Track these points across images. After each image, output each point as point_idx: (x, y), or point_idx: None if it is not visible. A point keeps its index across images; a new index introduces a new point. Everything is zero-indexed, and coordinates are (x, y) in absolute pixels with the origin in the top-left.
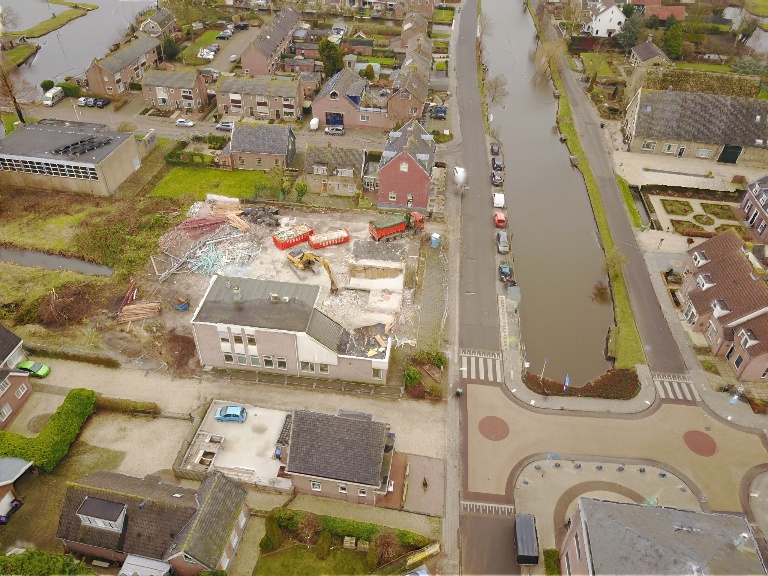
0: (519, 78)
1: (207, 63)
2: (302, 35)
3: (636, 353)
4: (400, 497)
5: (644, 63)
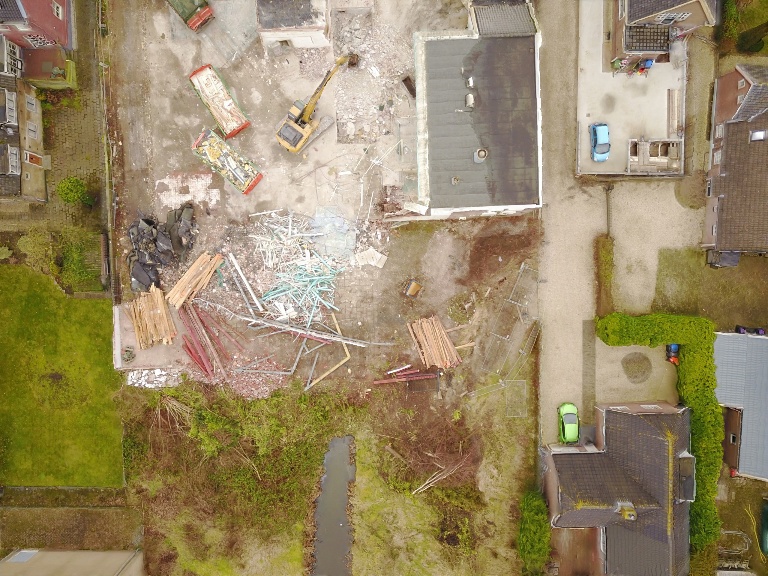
0: None
1: None
2: None
3: None
4: None
5: None
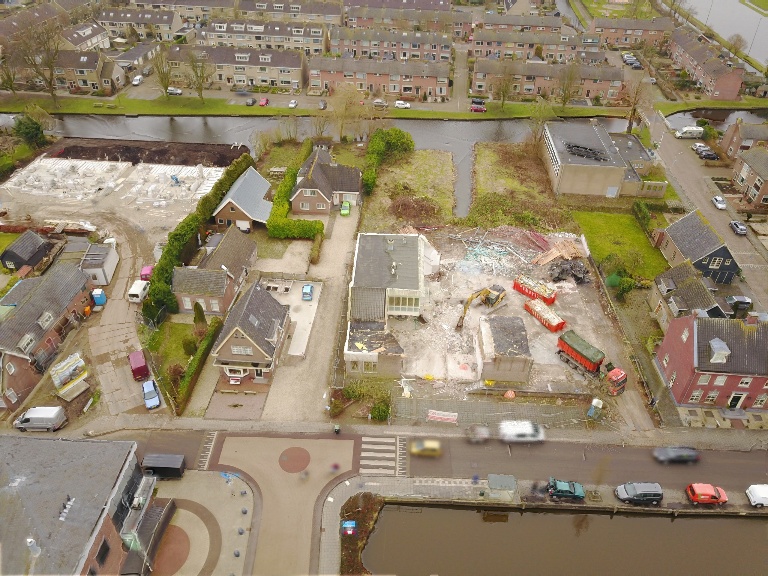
0: None
1: None
2: None
3: None
4: None
5: None
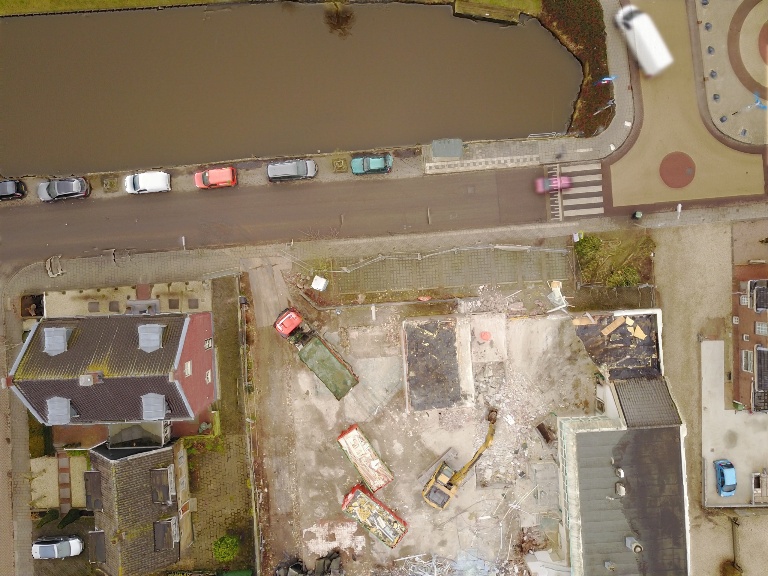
0: None
1: None
2: None
3: None
4: None
5: None
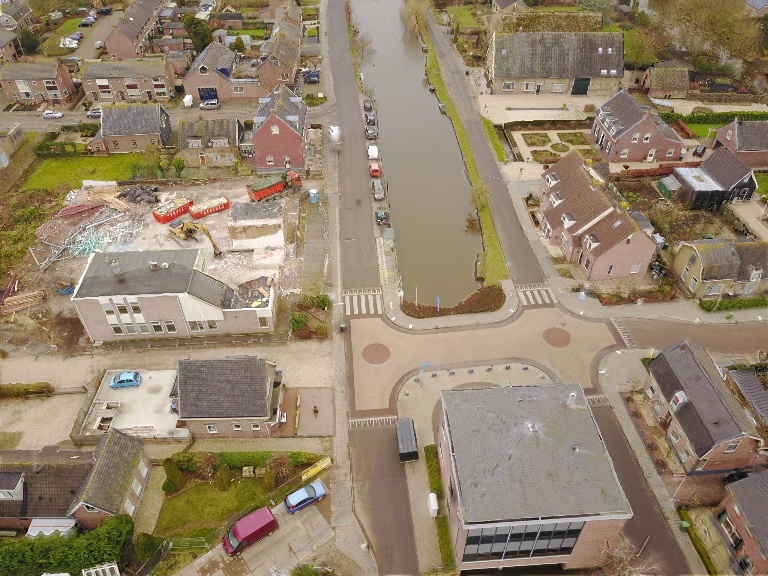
0: (390, 37)
1: (71, 52)
2: (168, 14)
3: (501, 271)
4: (293, 426)
5: (503, 11)
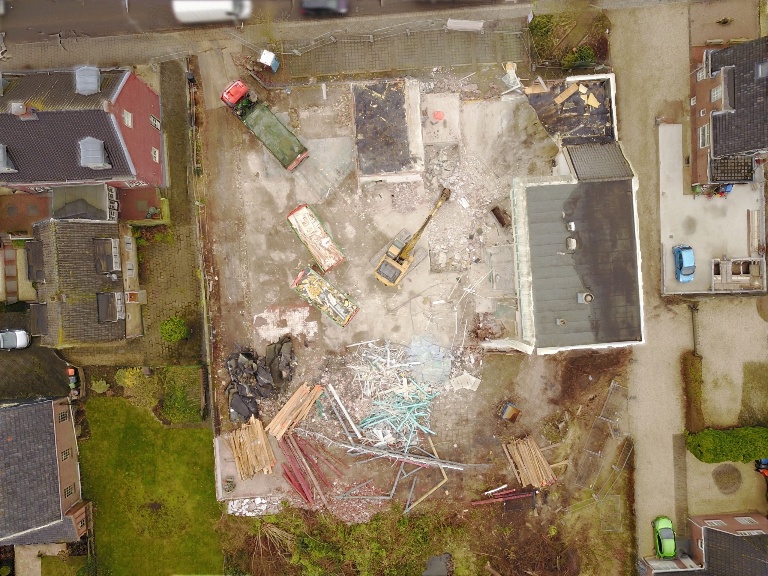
0: None
1: None
2: None
3: None
4: None
5: None
